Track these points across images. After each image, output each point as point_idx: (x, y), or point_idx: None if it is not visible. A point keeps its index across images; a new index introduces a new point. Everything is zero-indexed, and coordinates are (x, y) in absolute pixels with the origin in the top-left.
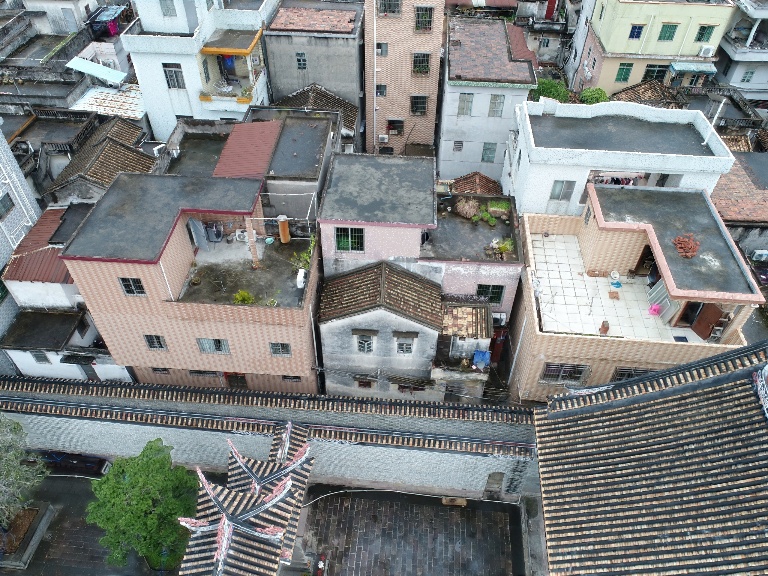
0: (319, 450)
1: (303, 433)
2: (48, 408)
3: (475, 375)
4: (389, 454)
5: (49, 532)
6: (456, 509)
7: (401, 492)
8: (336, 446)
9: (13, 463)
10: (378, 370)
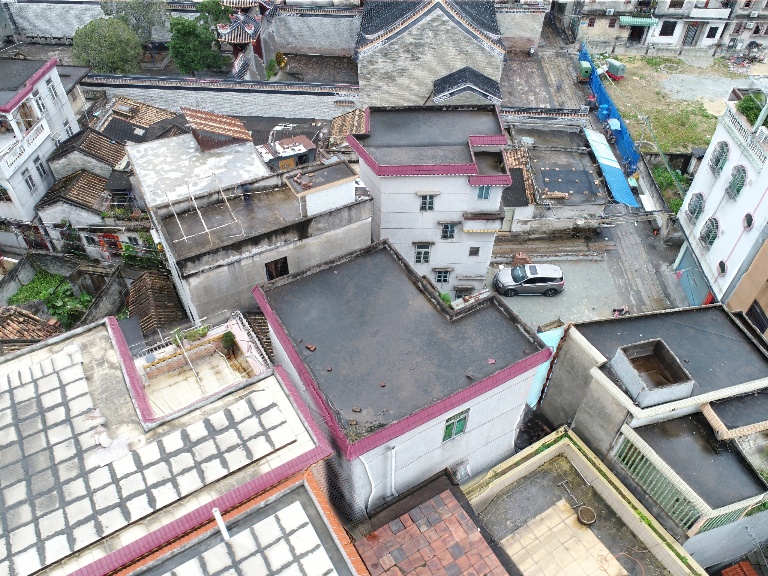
0: (284, 24)
1: (277, 8)
2: (169, 6)
3: (353, 1)
4: (314, 22)
5: (169, 63)
6: (346, 58)
7: (322, 55)
8: (291, 19)
9: (164, 0)
10: (311, 4)
